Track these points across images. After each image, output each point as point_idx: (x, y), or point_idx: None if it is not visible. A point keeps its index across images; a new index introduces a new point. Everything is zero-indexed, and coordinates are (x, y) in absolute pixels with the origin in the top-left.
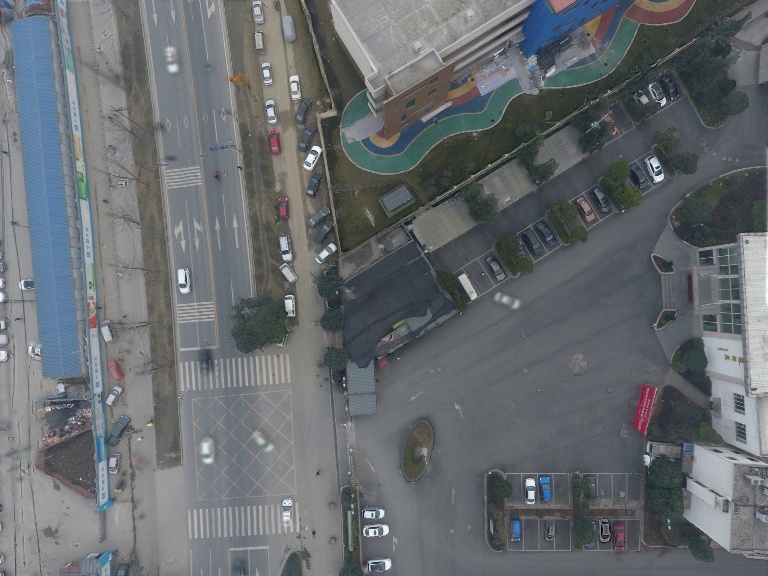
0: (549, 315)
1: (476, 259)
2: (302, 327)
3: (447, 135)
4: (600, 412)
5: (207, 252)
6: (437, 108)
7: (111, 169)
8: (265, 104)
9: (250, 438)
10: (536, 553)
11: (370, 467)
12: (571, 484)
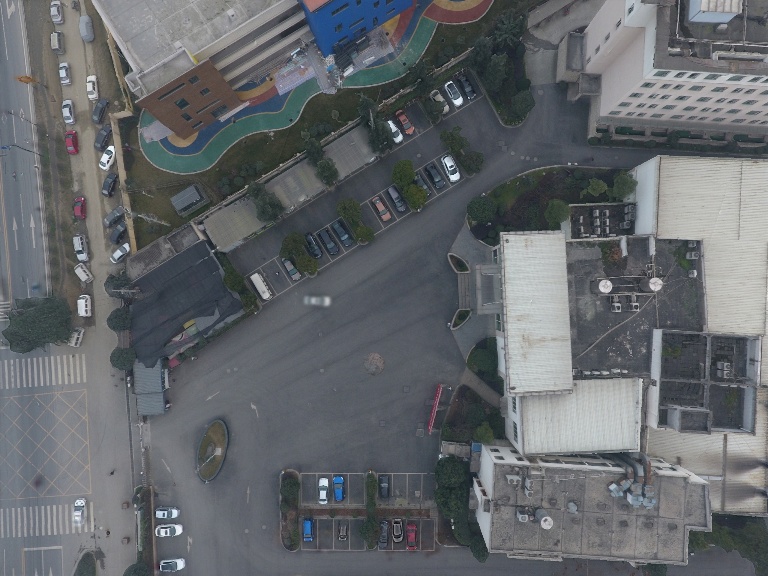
0: (346, 315)
1: (273, 259)
2: (98, 327)
3: (244, 135)
4: (396, 412)
5: (4, 252)
6: (235, 108)
7: None
8: (62, 104)
9: (45, 438)
10: (330, 553)
11: (165, 467)
12: None
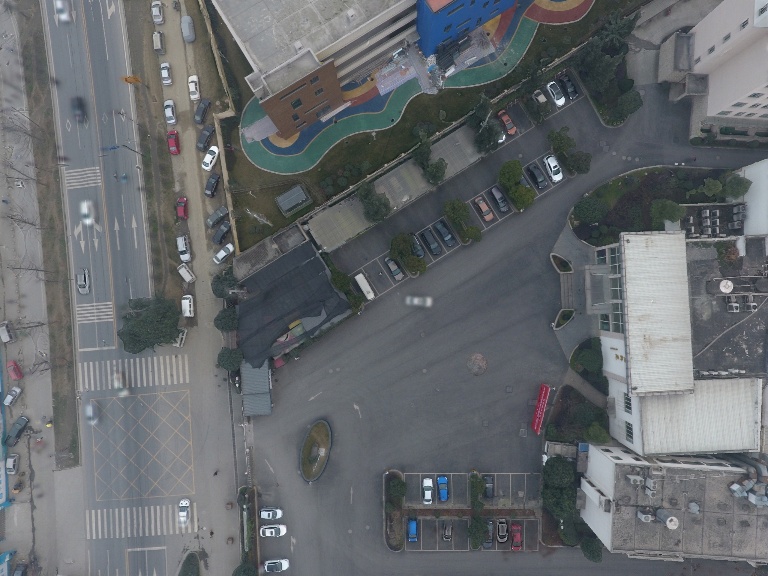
0: (448, 315)
1: (375, 259)
2: (201, 327)
3: (346, 135)
4: (499, 412)
5: (106, 252)
6: (336, 108)
7: (7, 170)
8: (164, 104)
9: (148, 438)
10: (434, 553)
11: (268, 467)
12: (469, 484)
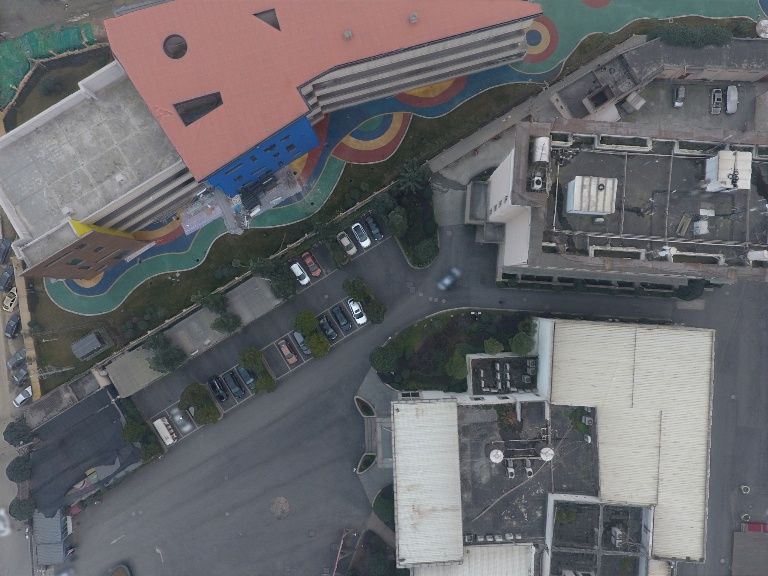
0: (252, 458)
1: None
2: (2, 470)
3: (150, 275)
4: (301, 556)
5: None
6: (140, 248)
7: None
8: None
9: None
10: None
11: None
12: None
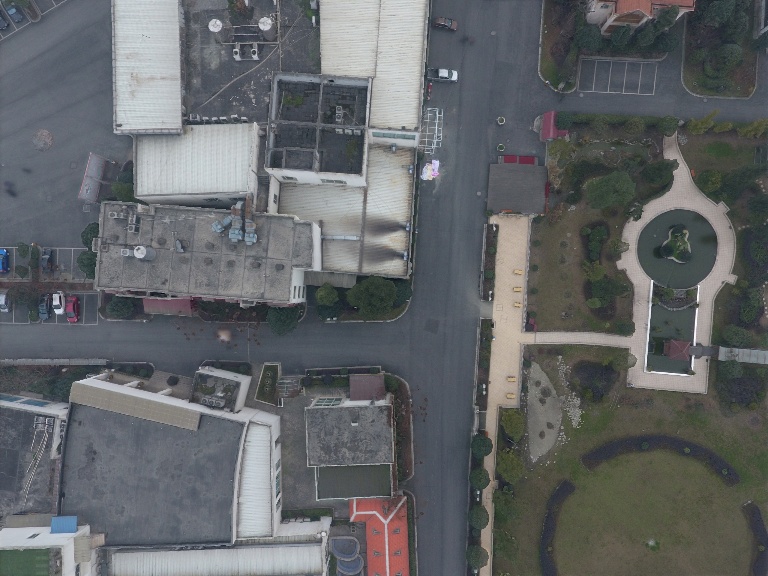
0: (16, 91)
1: None
2: None
3: None
4: (63, 187)
5: None
6: None
7: None
8: None
9: None
10: None
11: None
12: None
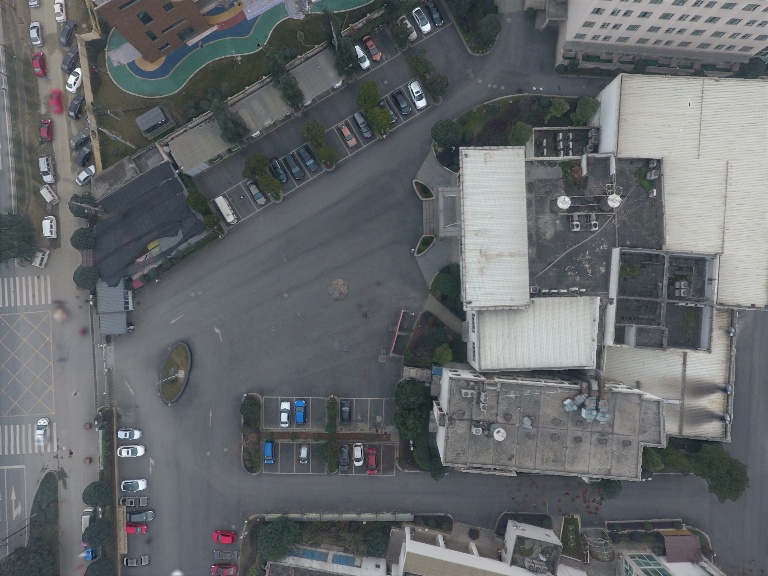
0: (310, 240)
1: (239, 183)
2: (64, 249)
3: (212, 59)
4: (359, 337)
5: None
6: (202, 32)
7: None
8: (30, 26)
9: (9, 358)
10: (291, 476)
11: (129, 389)
12: None
